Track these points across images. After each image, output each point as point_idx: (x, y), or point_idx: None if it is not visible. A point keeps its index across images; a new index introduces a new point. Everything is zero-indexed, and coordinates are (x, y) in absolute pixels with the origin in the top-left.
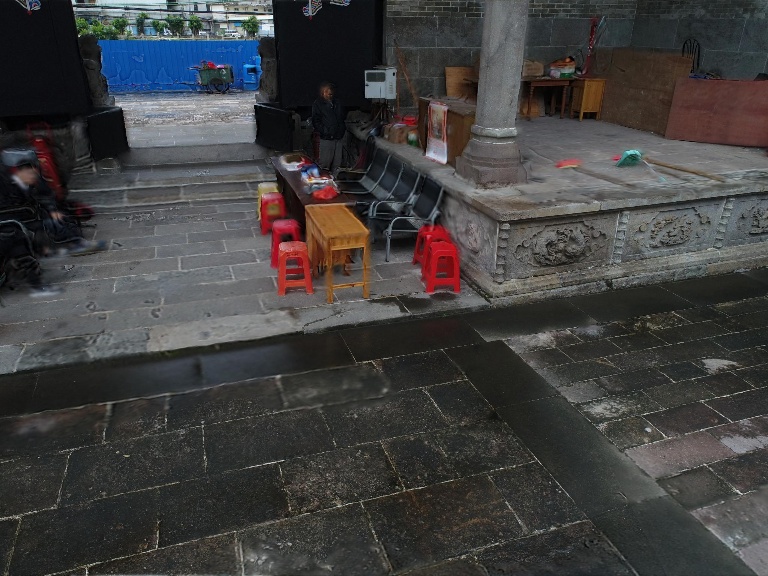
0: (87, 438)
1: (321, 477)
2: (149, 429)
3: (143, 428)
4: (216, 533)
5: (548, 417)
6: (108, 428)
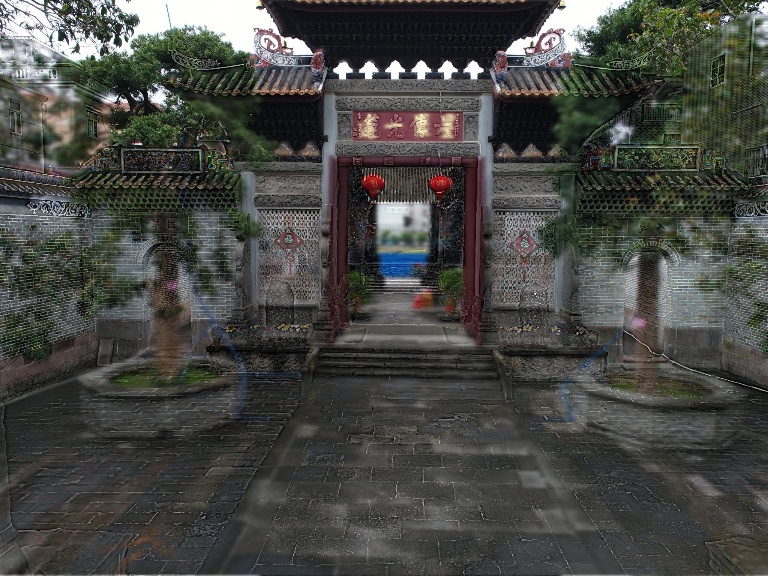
0: (510, 570)
1: (382, 529)
2: (473, 568)
3: (477, 570)
4: (434, 520)
5: (242, 533)
6: (499, 574)
